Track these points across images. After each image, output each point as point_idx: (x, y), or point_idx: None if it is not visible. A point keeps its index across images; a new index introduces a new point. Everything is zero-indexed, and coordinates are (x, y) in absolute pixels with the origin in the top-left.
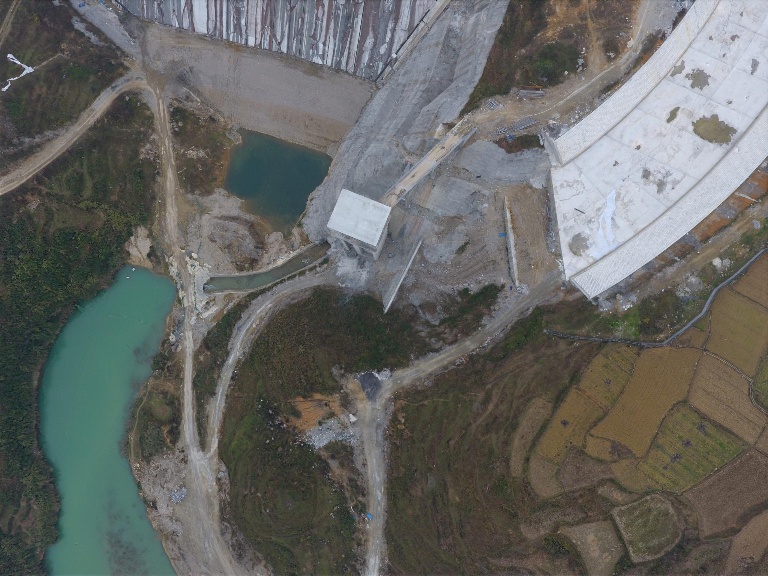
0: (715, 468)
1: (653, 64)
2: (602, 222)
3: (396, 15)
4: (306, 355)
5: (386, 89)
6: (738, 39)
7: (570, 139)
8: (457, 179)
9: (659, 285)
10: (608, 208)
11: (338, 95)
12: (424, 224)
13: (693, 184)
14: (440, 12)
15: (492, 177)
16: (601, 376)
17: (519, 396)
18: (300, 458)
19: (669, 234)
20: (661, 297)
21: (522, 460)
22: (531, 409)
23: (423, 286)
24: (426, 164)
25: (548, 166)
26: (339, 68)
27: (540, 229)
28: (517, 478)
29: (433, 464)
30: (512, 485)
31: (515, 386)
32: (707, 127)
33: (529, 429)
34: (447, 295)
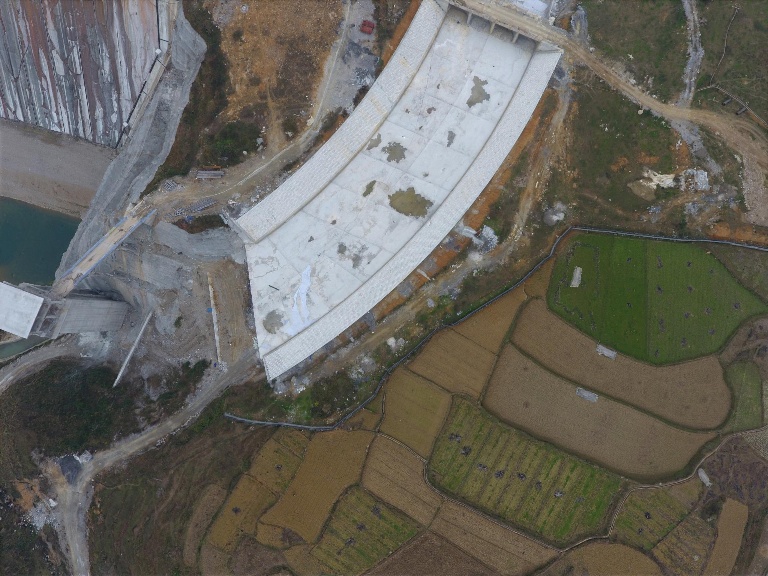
0: (390, 551)
1: (338, 141)
2: (297, 299)
3: (116, 86)
4: (8, 438)
5: (116, 159)
6: (434, 111)
7: (254, 218)
8: (159, 256)
9: (332, 367)
10: (303, 284)
11: (79, 162)
12: (148, 296)
13: (389, 258)
14: (156, 84)
15: (192, 253)
16: (272, 461)
17: (196, 483)
18: (21, 540)
19: (354, 312)
20: (332, 380)
21: (196, 549)
22: (206, 496)
23: (154, 358)
24: (104, 247)
25: (242, 243)
26: (78, 136)
27: (240, 306)
28: (190, 568)
29: (120, 552)
30: (185, 575)
31: (193, 472)
32: (403, 200)
33: (203, 517)
34: (173, 368)
